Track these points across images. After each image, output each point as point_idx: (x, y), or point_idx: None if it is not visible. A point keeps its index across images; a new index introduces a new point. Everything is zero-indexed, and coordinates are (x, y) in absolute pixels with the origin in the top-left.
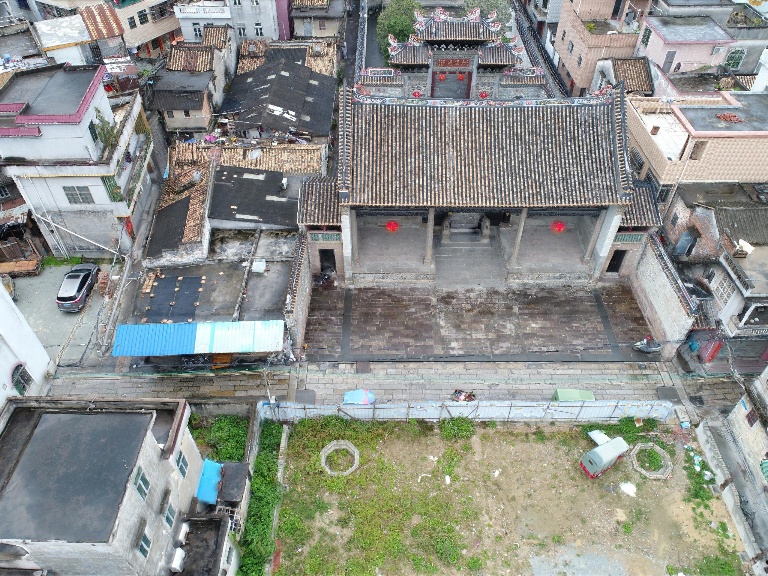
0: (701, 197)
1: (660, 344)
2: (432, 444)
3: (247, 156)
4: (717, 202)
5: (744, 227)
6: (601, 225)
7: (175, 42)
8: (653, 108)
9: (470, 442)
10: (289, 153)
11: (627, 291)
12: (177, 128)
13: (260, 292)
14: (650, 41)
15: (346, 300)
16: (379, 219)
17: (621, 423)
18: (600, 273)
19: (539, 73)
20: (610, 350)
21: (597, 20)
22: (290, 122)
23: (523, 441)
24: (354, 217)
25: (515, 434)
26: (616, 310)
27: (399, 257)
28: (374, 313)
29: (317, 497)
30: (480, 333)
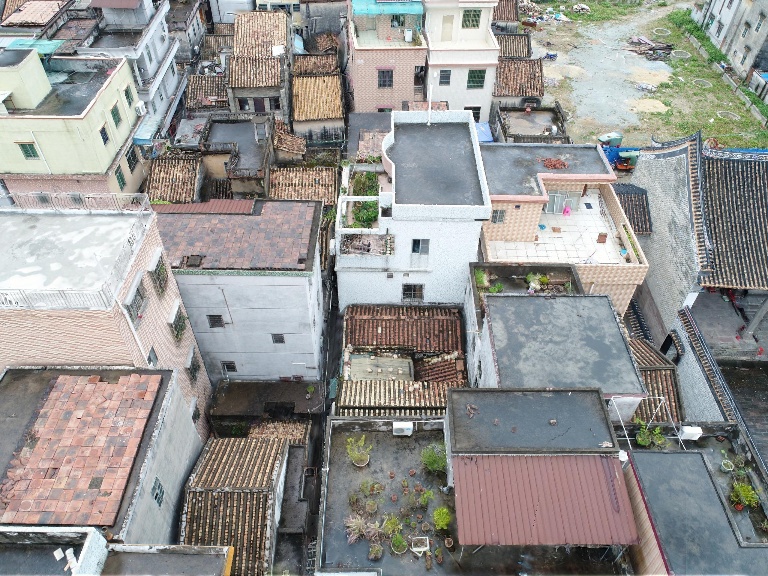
0: None
1: None
2: None
3: None
4: None
5: None
6: None
7: None
8: None
9: None
10: None
11: None
12: None
13: None
14: None
15: None
16: None
17: None
18: None
19: None
20: None
21: None
22: None
23: None
24: None
25: None
26: None
27: None
28: None
29: (760, 142)
30: None
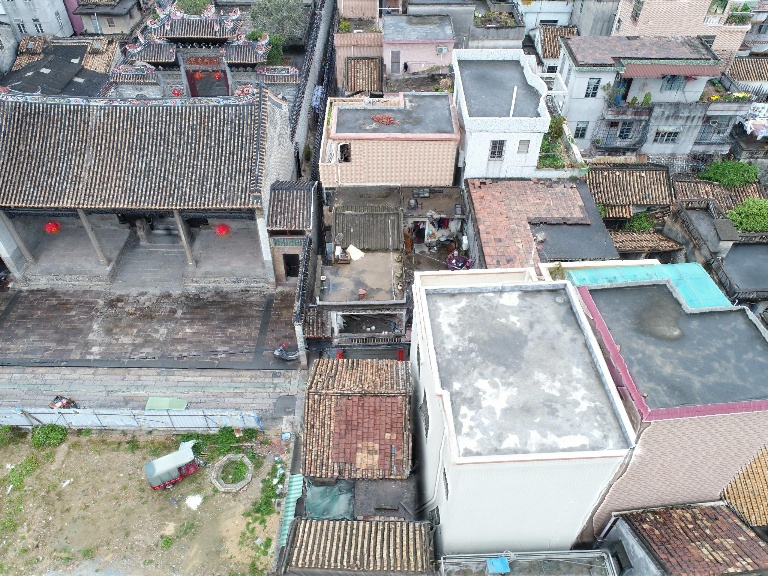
0: (341, 201)
1: (297, 352)
2: (17, 452)
3: None
4: (357, 206)
5: (360, 232)
6: None
7: None
8: None
9: (56, 450)
10: None
11: None
12: None
13: None
14: None
15: (11, 302)
16: (74, 219)
17: (219, 433)
18: (278, 277)
19: (294, 72)
20: (252, 357)
21: (364, 19)
22: None
23: (113, 450)
24: (4, 217)
25: (108, 443)
26: (281, 316)
27: (79, 259)
28: (32, 316)
29: None
30: (128, 338)
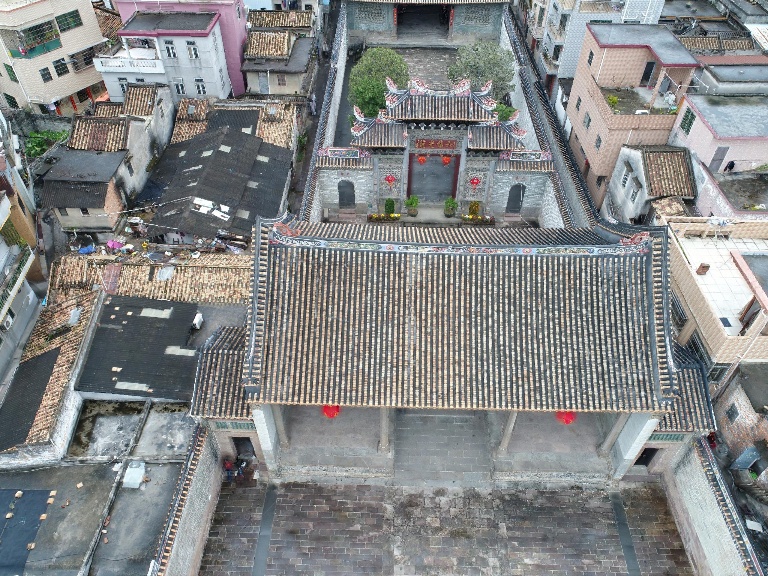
0: None
1: None
2: None
3: (155, 276)
4: None
5: None
6: (627, 418)
7: (103, 96)
8: (699, 230)
9: None
10: (211, 273)
11: (660, 499)
12: (74, 227)
13: (128, 524)
14: (693, 129)
15: (266, 506)
16: None
17: None
18: None
19: (546, 158)
20: None
21: (621, 88)
22: (220, 223)
23: None
24: None
25: None
26: (645, 535)
27: (345, 438)
28: (303, 532)
29: None
30: (450, 574)
